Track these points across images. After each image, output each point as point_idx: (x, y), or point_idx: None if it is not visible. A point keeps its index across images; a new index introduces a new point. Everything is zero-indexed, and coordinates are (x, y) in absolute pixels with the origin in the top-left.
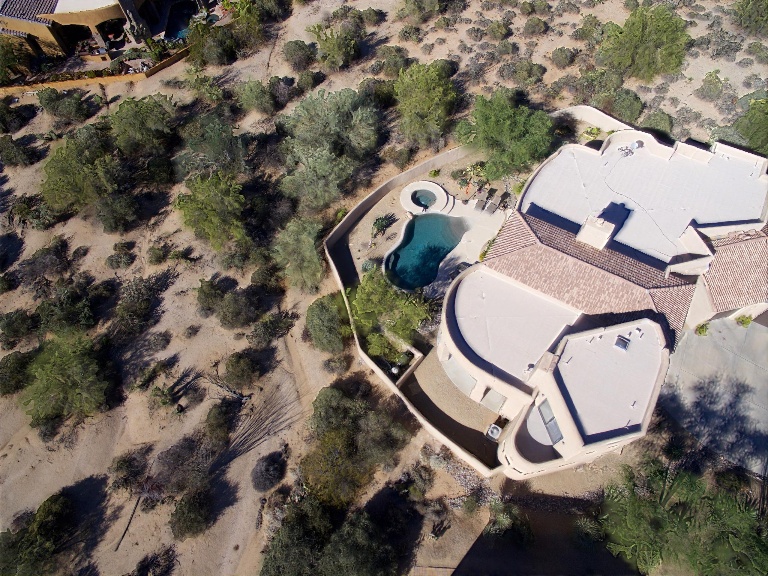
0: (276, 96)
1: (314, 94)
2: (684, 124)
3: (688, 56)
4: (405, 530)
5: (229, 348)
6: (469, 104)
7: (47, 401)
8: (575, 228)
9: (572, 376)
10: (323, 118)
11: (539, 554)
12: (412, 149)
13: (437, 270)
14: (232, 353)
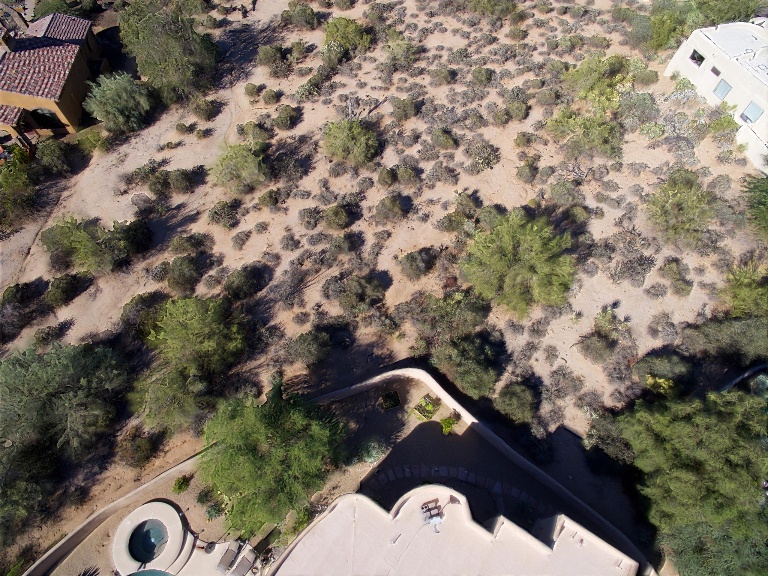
0: (2, 323)
1: (67, 312)
2: (557, 399)
3: (582, 273)
4: None
5: None
6: (270, 344)
7: None
8: None
9: None
10: None
11: None
12: (167, 429)
13: None
14: None
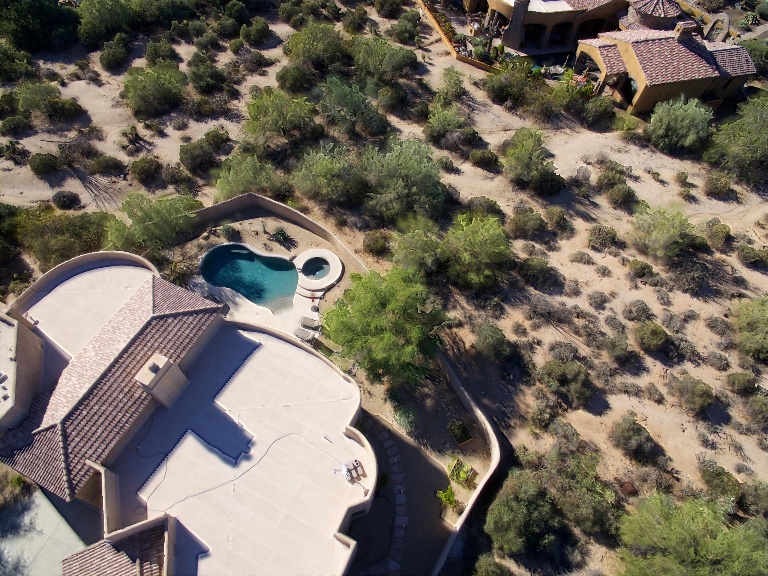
0: None
1: (468, 168)
2: None
3: None
4: None
5: (170, 162)
6: (485, 309)
7: (129, 80)
8: (215, 387)
9: None
10: (394, 161)
11: None
12: None
13: None
14: None
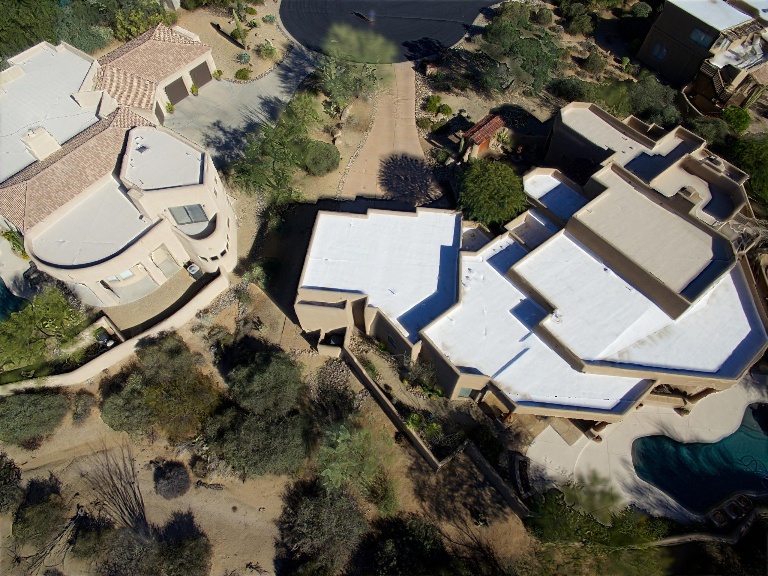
0: None
1: None
2: None
3: None
4: (253, 351)
5: (3, 545)
6: None
7: None
8: None
9: (154, 183)
10: None
11: (287, 260)
12: None
13: (21, 302)
14: (12, 538)
